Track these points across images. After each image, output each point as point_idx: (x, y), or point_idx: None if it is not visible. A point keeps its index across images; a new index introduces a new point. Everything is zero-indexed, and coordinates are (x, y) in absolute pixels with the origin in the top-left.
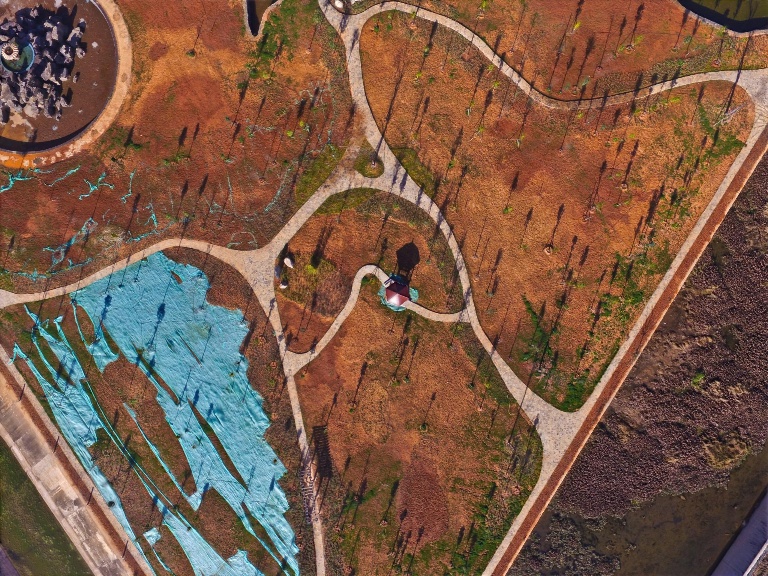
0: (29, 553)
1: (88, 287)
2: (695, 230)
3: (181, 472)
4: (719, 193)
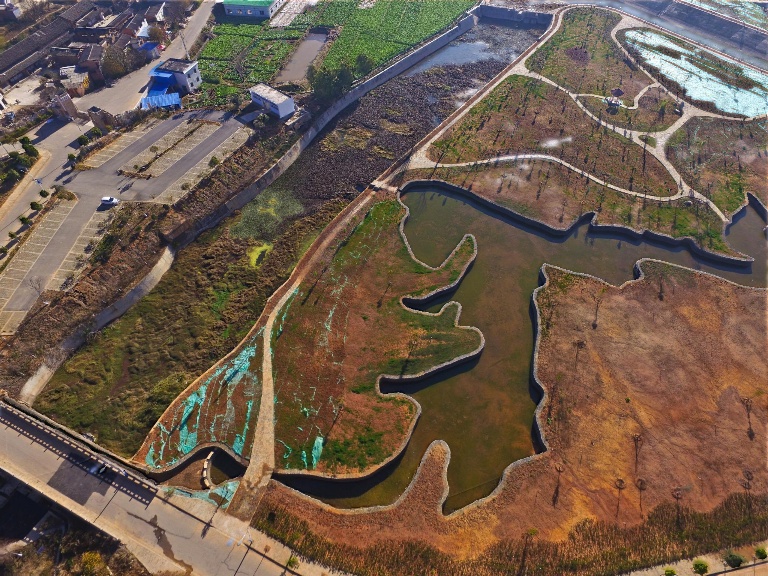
0: None
1: None
2: (458, 119)
3: (695, 63)
4: (446, 129)
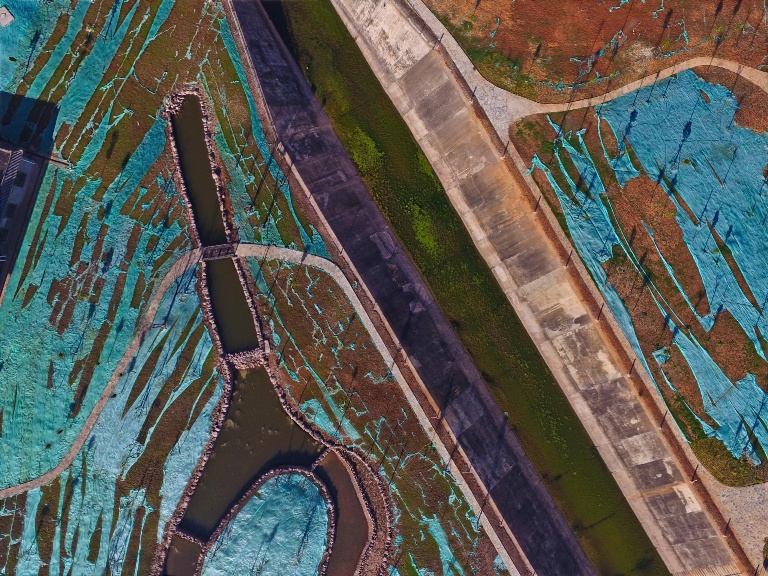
0: (503, 376)
1: (614, 101)
2: None
3: (695, 293)
4: None
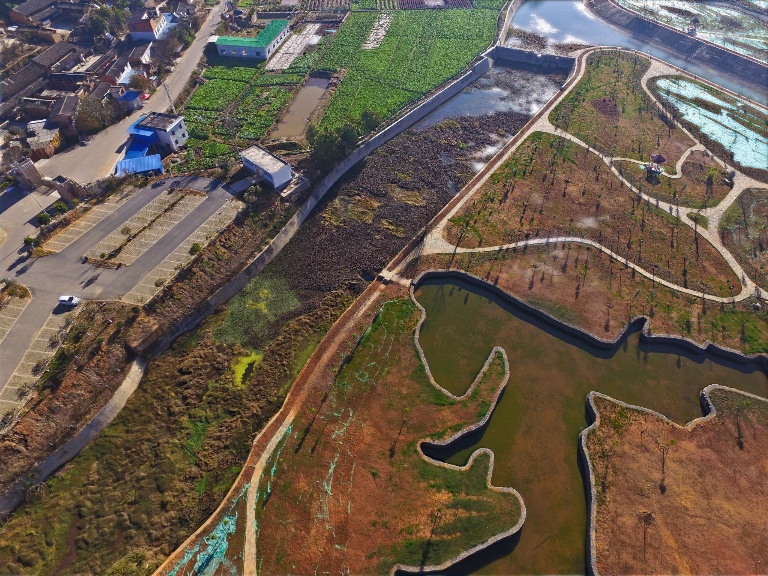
0: None
1: None
2: (478, 187)
3: (738, 120)
4: (464, 201)
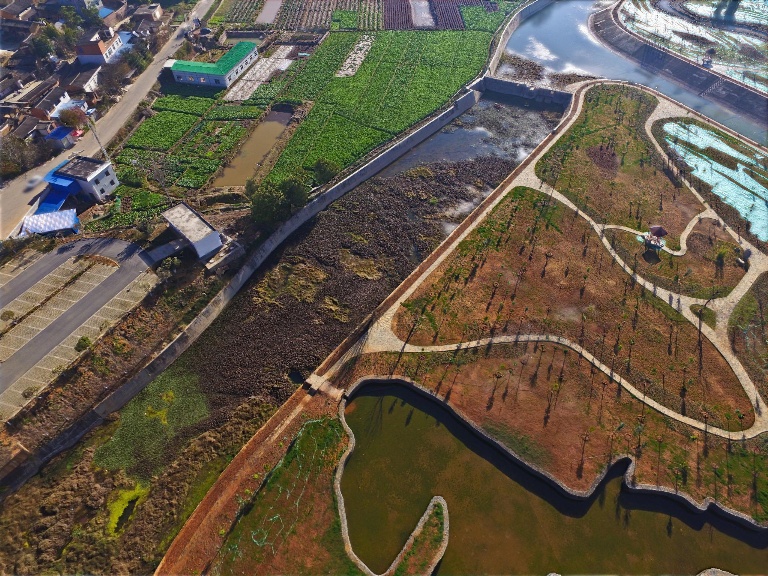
0: None
1: None
2: (442, 260)
3: (757, 177)
4: (424, 278)
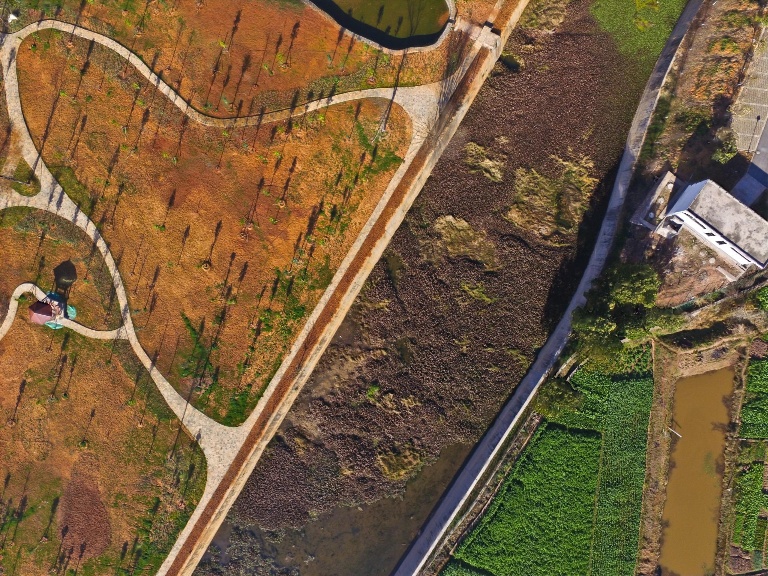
0: None
1: None
2: (355, 245)
3: None
4: (378, 209)
